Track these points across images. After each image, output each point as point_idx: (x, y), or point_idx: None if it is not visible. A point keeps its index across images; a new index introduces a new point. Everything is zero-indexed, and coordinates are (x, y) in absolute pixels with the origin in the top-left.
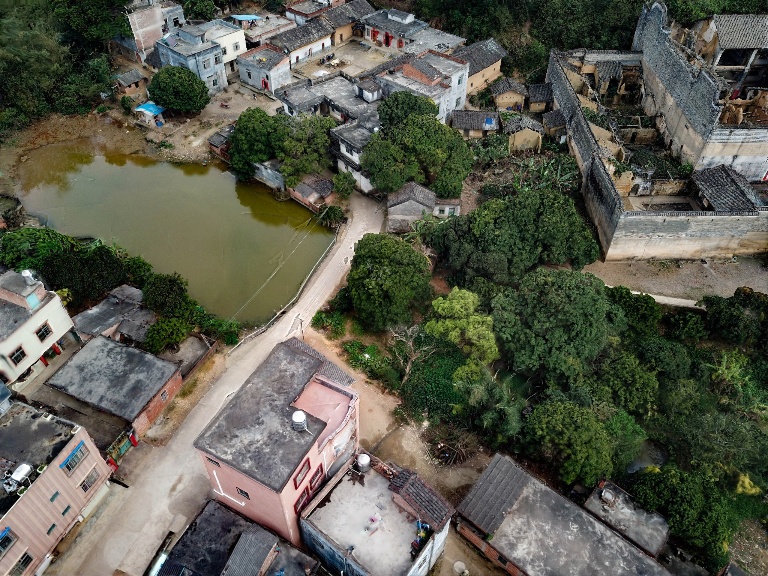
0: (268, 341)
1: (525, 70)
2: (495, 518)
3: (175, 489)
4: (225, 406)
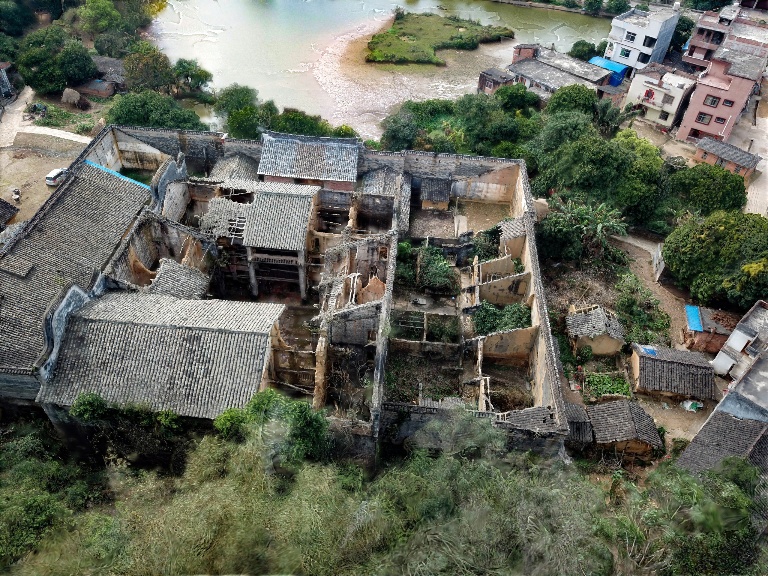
0: None
1: None
2: (610, 86)
3: (767, 136)
4: (764, 65)
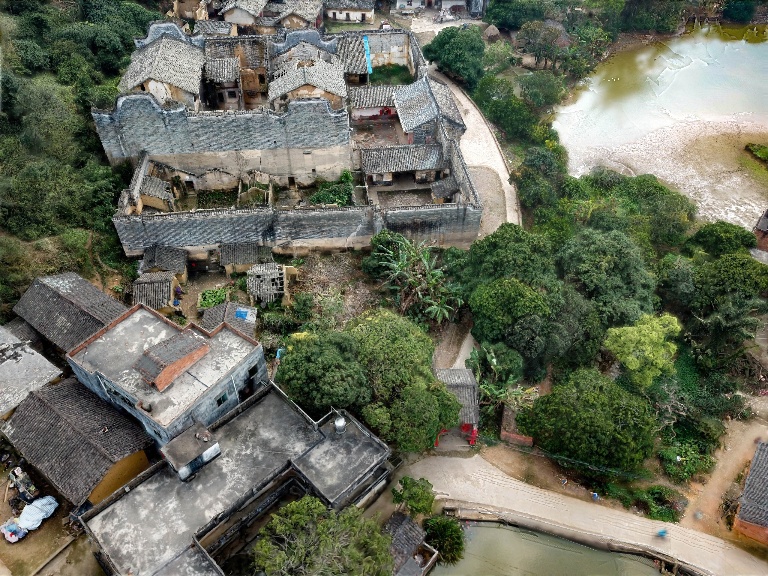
0: (734, 573)
1: (91, 271)
2: None
3: None
4: None
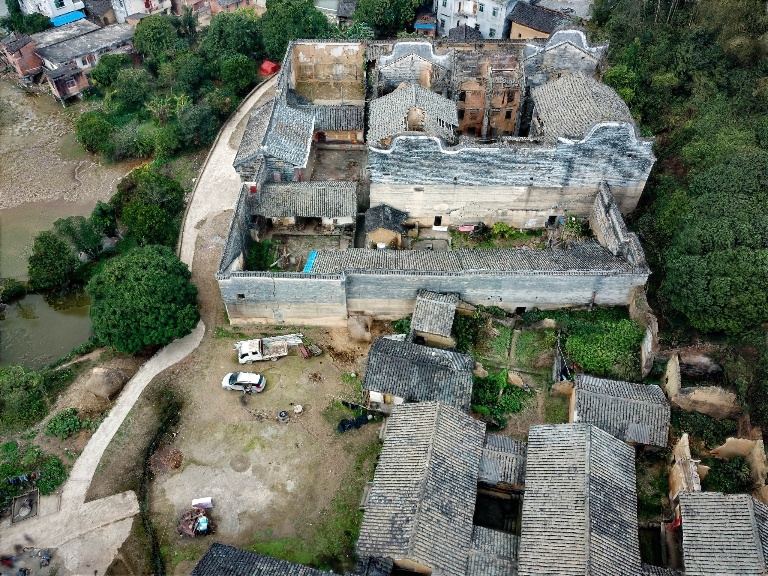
0: (265, 1)
1: None
2: None
3: None
4: None
